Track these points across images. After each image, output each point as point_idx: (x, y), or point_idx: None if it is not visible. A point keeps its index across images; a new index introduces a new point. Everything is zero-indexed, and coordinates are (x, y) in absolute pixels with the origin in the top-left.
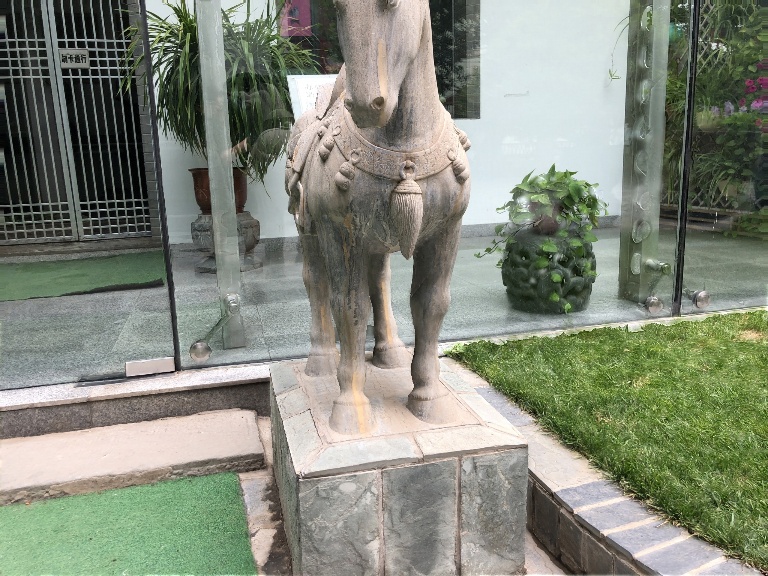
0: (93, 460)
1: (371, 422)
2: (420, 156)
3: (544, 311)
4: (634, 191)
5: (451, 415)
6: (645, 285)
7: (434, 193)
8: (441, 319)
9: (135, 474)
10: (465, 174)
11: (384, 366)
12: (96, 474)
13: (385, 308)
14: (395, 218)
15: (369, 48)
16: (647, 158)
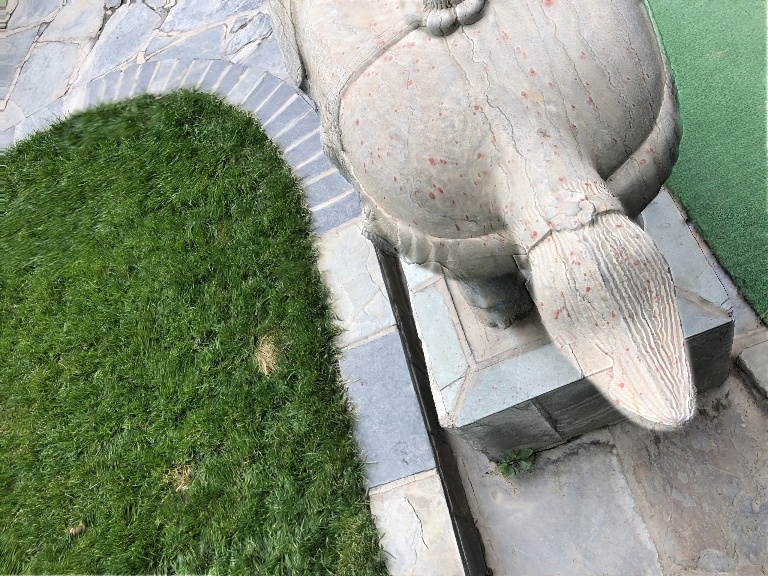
0: None
1: None
2: None
3: None
4: None
5: None
6: None
7: None
8: None
9: None
10: None
11: None
12: None
13: None
14: None
15: None
16: None
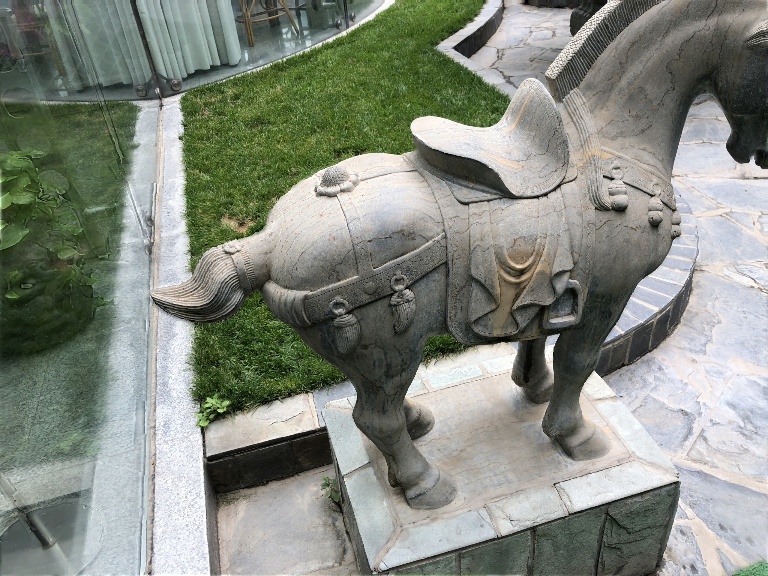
0: None
1: None
2: None
3: (81, 326)
4: (8, 141)
5: None
6: (95, 235)
7: None
8: None
9: None
10: None
11: (431, 425)
12: None
13: None
14: None
15: None
16: (32, 95)
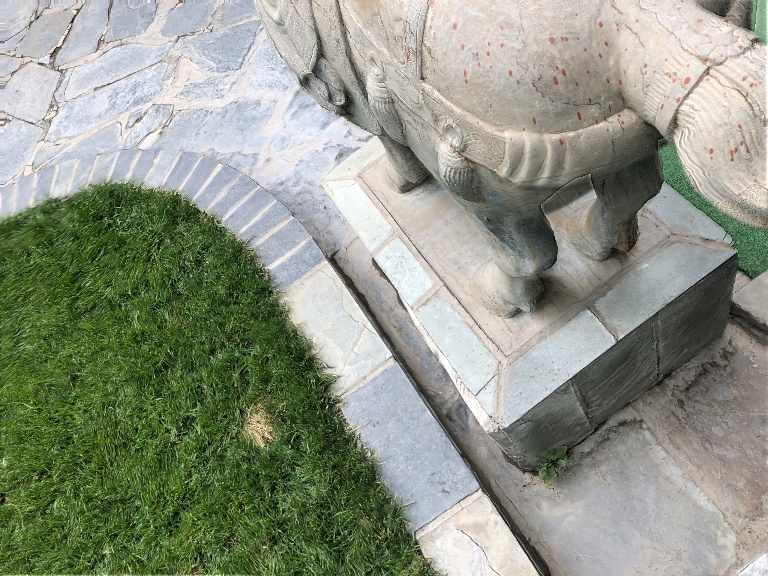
0: None
1: None
2: None
3: None
4: None
5: None
6: None
7: None
8: None
9: None
10: None
11: None
12: None
13: None
14: None
15: None
16: None
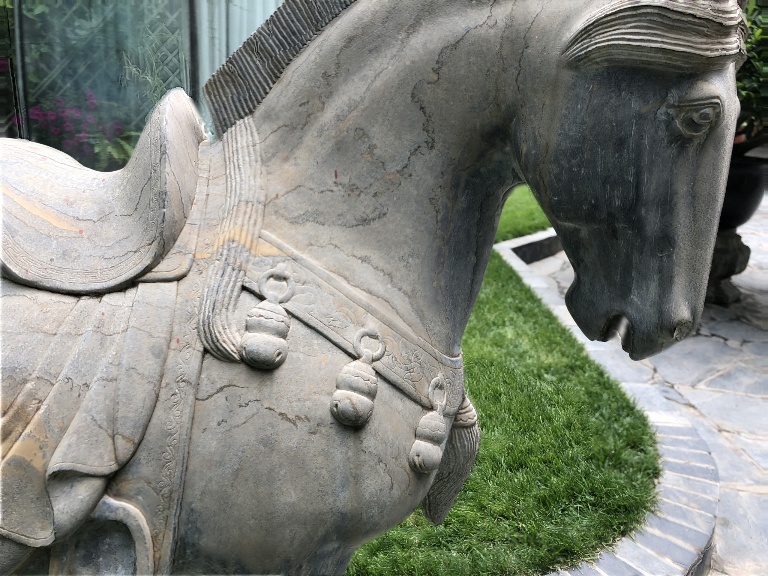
0: None
1: None
2: None
3: None
4: None
5: None
6: None
7: None
8: None
9: None
10: None
11: None
12: None
13: None
14: (458, 472)
15: None
16: None
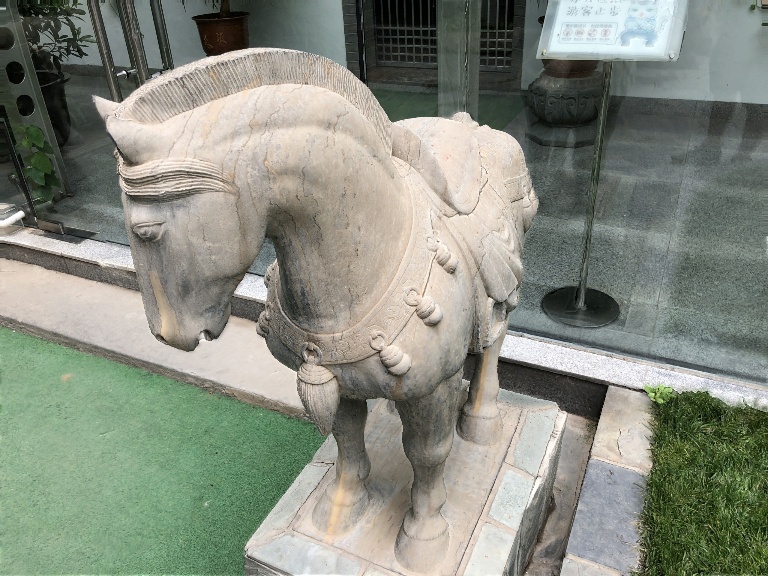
0: (264, 373)
1: (344, 526)
2: (326, 341)
3: None
4: None
5: (423, 564)
6: None
7: (356, 379)
8: (432, 468)
9: (279, 403)
10: (397, 370)
11: (460, 432)
12: (254, 391)
13: (483, 369)
14: None
15: (141, 279)
16: None
